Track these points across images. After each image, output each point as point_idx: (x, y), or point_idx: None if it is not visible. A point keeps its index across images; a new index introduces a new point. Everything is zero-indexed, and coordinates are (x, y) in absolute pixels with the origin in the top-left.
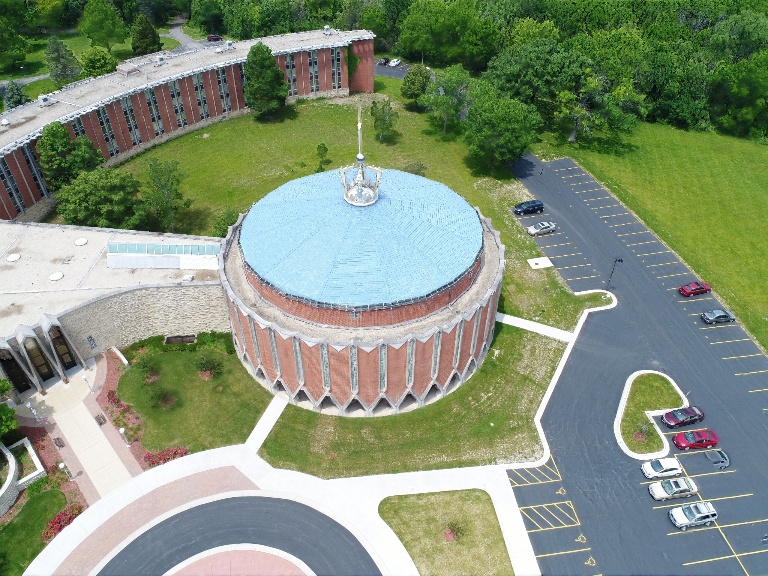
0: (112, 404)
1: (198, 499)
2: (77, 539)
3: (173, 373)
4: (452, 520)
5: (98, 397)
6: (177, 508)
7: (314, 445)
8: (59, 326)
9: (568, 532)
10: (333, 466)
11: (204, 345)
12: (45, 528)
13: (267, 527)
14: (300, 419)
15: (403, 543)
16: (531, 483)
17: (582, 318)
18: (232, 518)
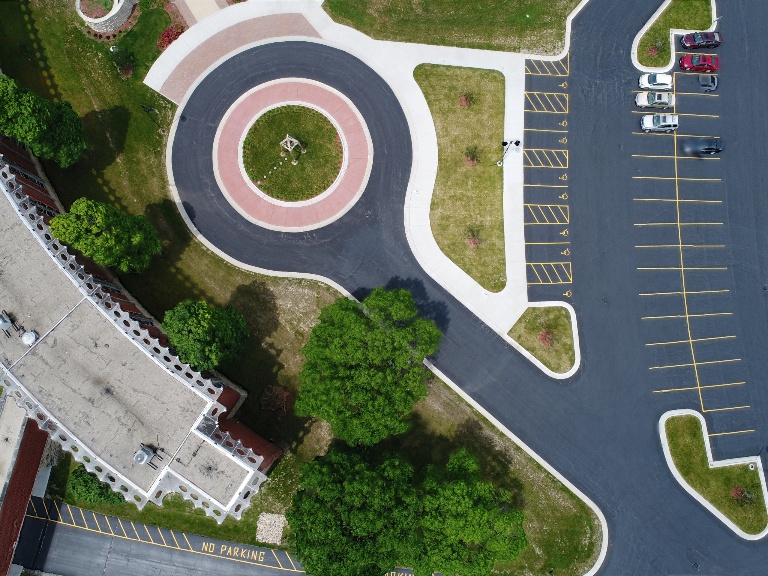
0: None
1: (273, 37)
2: (184, 52)
3: None
4: (469, 91)
5: None
6: (257, 42)
7: (370, 7)
8: None
9: (556, 117)
10: (383, 29)
11: None
12: (158, 39)
13: (326, 70)
14: None
15: (427, 101)
16: (542, 74)
17: None
18: (299, 58)
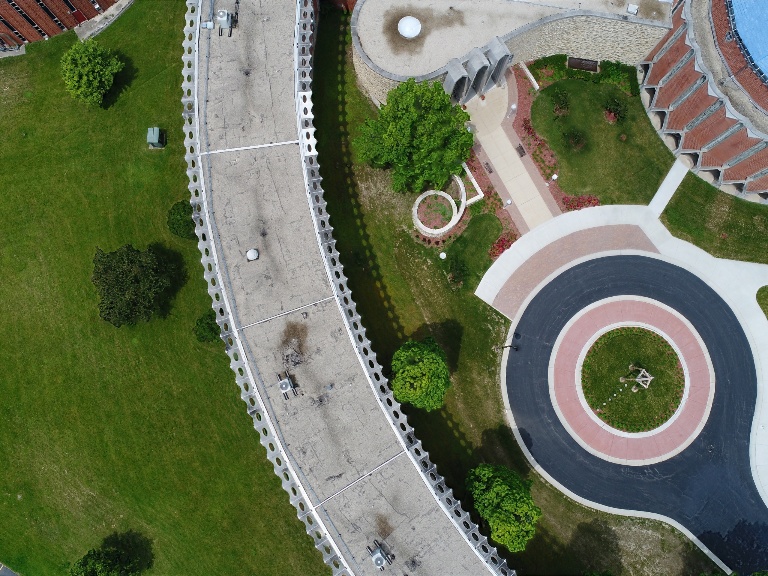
0: (529, 135)
1: (609, 250)
2: (517, 263)
3: (581, 109)
4: None
5: (514, 123)
6: (593, 254)
7: (709, 221)
8: (509, 54)
9: None
10: (723, 246)
11: (608, 78)
12: (490, 247)
13: (664, 288)
14: (699, 191)
15: None
16: None
17: None
18: (637, 274)
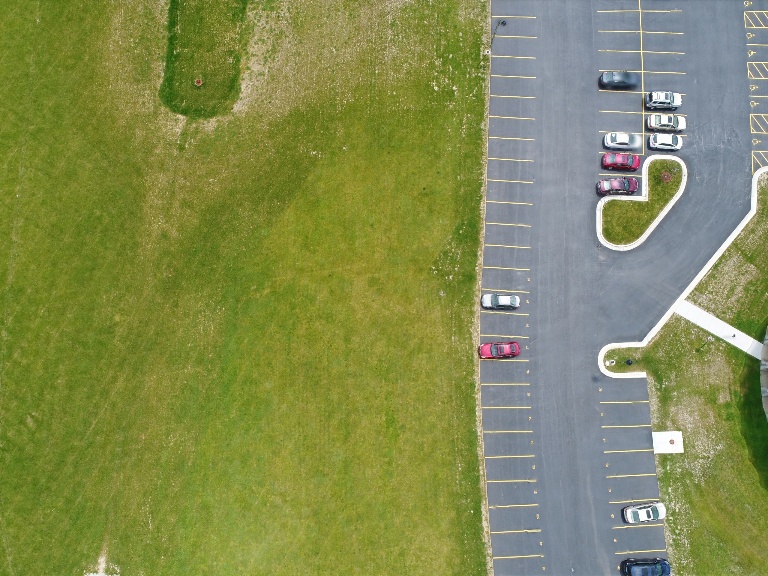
0: None
1: None
2: None
3: None
4: None
5: None
6: None
7: None
8: None
9: (762, 110)
10: None
11: None
12: None
13: None
14: None
15: None
16: None
17: (654, 333)
18: None
